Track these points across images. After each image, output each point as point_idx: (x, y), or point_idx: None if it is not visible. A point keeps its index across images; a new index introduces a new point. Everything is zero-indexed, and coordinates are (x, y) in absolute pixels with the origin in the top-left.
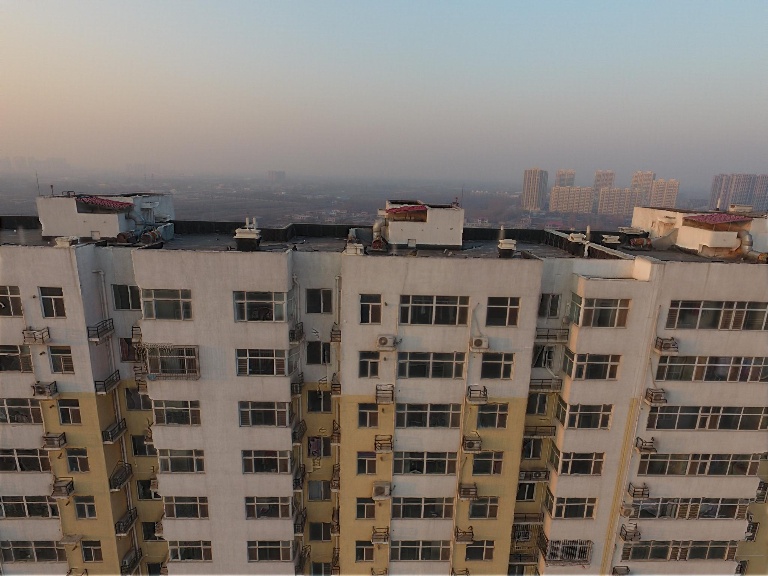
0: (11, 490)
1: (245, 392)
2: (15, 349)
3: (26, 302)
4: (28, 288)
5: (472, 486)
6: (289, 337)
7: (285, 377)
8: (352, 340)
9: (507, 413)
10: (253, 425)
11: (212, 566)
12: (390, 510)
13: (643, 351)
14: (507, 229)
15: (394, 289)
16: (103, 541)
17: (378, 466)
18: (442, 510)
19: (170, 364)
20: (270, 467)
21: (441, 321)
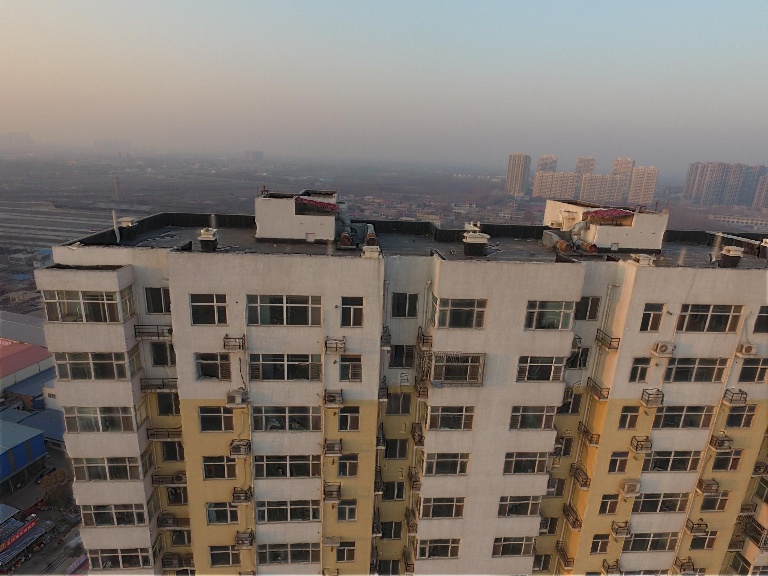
0: (278, 495)
1: (520, 397)
2: (305, 358)
3: (327, 312)
4: (331, 298)
5: (713, 482)
6: None
7: (560, 383)
8: (630, 347)
9: (754, 414)
10: (520, 428)
11: (457, 562)
12: (632, 505)
13: None
14: (671, 231)
15: (677, 299)
16: (359, 542)
17: (629, 465)
18: (677, 504)
19: (455, 371)
20: (527, 468)
21: (713, 329)
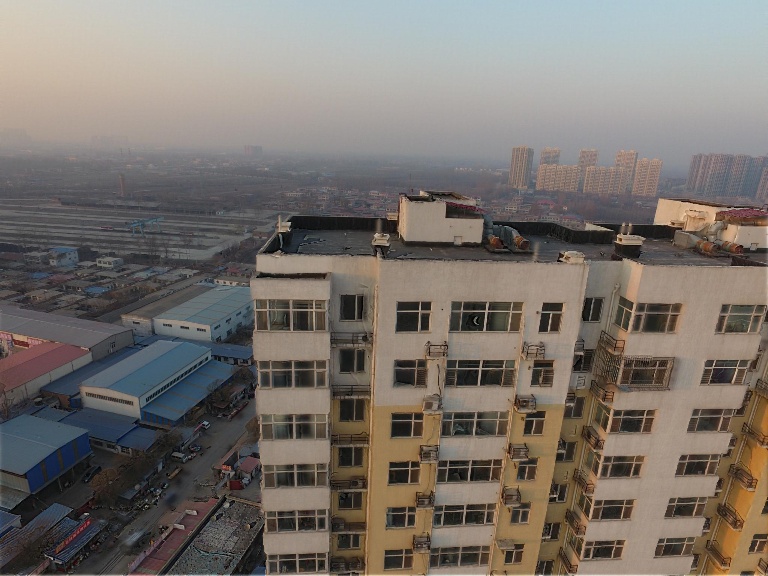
0: (457, 499)
1: (702, 400)
2: (499, 364)
3: (527, 318)
4: (534, 304)
5: None
6: (758, 348)
7: (742, 385)
8: None
9: None
10: (697, 431)
11: (620, 563)
12: None
13: None
14: None
15: None
16: (528, 544)
17: None
18: None
19: (643, 375)
20: (697, 470)
21: None
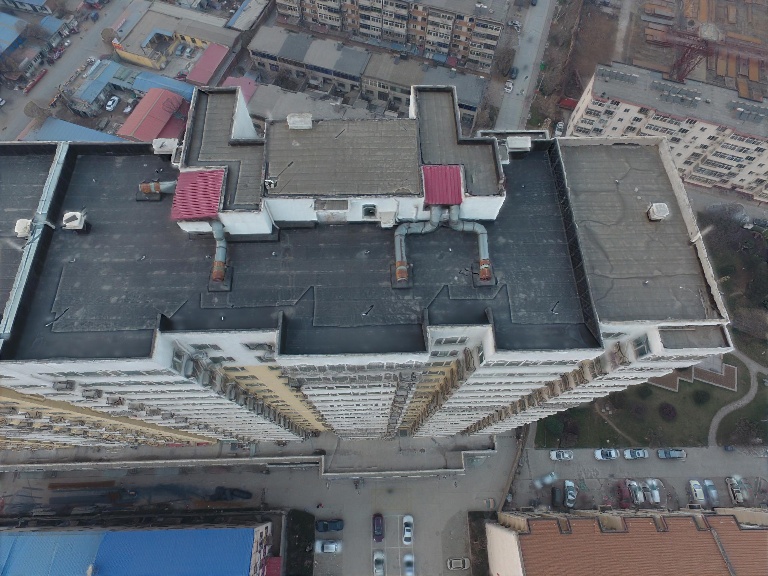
0: None
1: None
2: None
3: None
4: None
5: (7, 410)
6: None
7: None
8: None
9: None
10: None
11: None
12: None
13: (52, 383)
14: (10, 145)
15: None
16: None
17: None
18: None
19: None
20: None
21: None
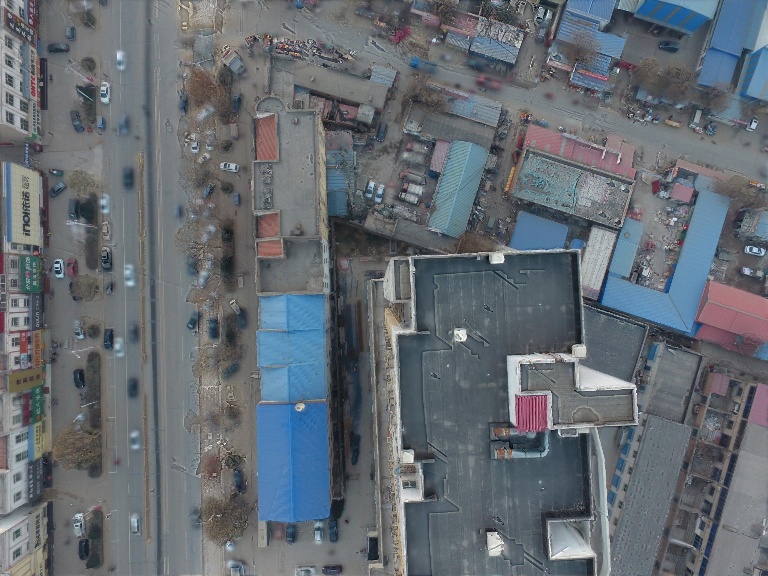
0: None
1: None
2: None
3: None
4: None
5: None
6: None
7: None
8: None
9: None
10: None
11: None
12: None
13: None
14: None
15: None
16: None
17: None
18: None
19: None
20: None
21: None
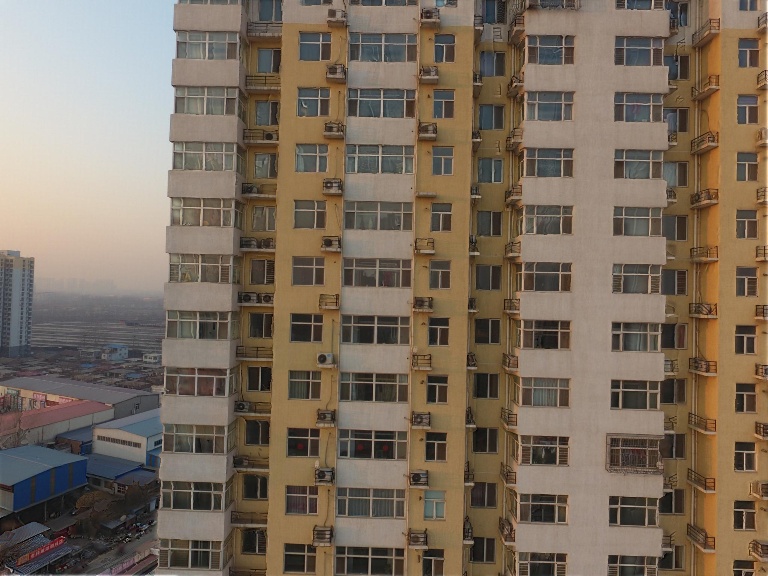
0: (371, 137)
1: (622, 26)
2: None
3: None
4: None
5: None
6: None
7: (664, 10)
8: None
9: None
10: None
11: (572, 240)
12: None
13: None
14: None
15: None
16: (456, 203)
17: (761, 112)
18: None
19: None
20: (641, 117)
21: None
